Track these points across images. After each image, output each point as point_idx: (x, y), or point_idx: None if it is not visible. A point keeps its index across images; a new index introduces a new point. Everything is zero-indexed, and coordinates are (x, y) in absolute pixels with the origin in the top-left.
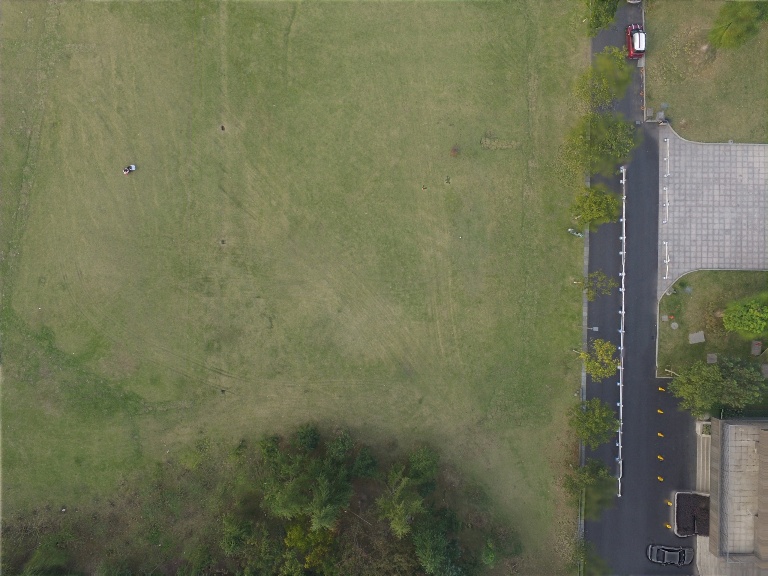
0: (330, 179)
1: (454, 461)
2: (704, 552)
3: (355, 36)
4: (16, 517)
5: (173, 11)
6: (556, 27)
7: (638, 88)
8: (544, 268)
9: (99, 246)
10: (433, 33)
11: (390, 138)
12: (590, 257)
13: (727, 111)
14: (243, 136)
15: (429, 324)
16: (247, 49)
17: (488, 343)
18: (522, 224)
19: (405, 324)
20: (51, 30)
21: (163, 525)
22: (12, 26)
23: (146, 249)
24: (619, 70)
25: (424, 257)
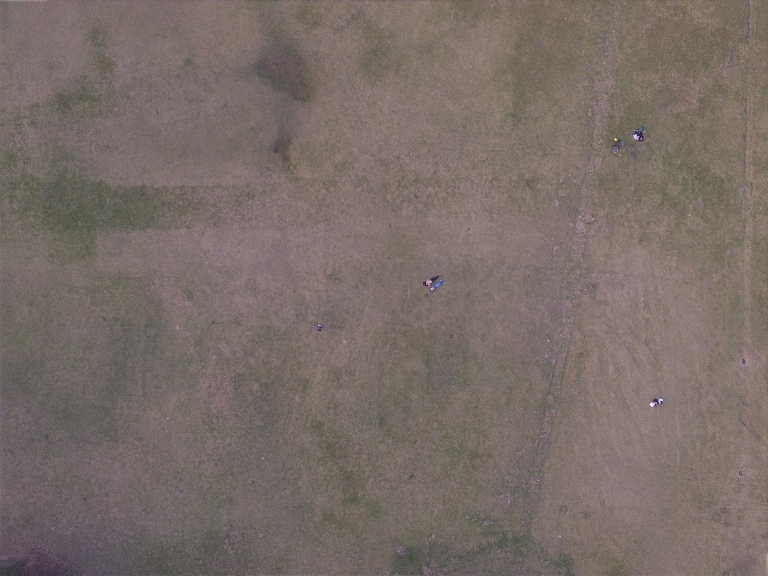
0: None
1: None
2: None
3: None
4: None
5: (700, 244)
6: None
7: None
8: None
9: (623, 477)
10: None
11: None
12: None
13: None
14: (764, 370)
15: None
16: None
17: None
18: None
19: None
20: (577, 258)
21: None
22: (538, 253)
23: (667, 480)
24: None
25: None
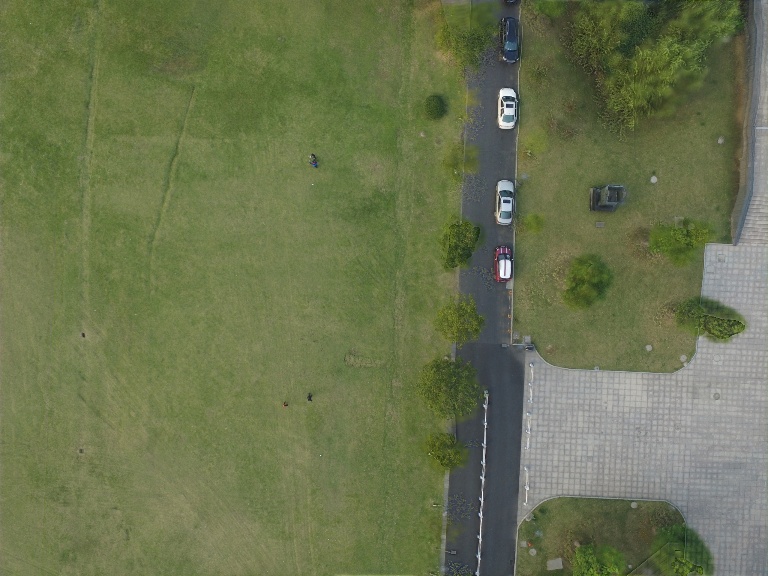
0: (190, 392)
1: None
2: None
3: (220, 247)
4: None
5: (35, 214)
6: (426, 244)
7: (506, 310)
8: (404, 489)
9: None
10: (300, 246)
11: (252, 353)
12: (450, 480)
13: (594, 338)
14: (104, 344)
15: (286, 543)
16: (110, 256)
17: (345, 563)
18: (384, 444)
19: (262, 542)
20: None
21: None
22: None
23: (2, 456)
24: (487, 291)
25: (283, 475)
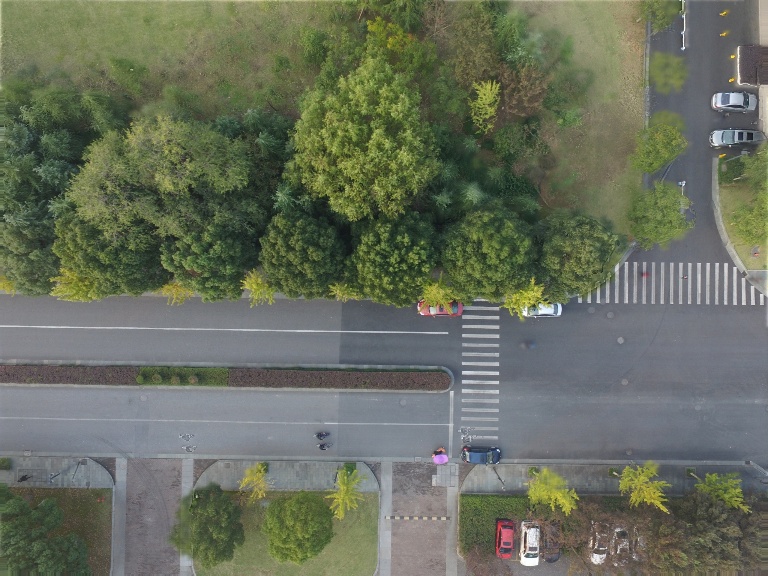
0: None
1: (521, 17)
2: (766, 104)
3: None
4: (83, 77)
5: None
6: None
7: None
8: None
9: None
10: None
11: None
12: None
13: None
14: None
15: None
16: None
17: None
18: None
19: None
20: None
21: (232, 79)
22: None
23: None
24: None
25: None
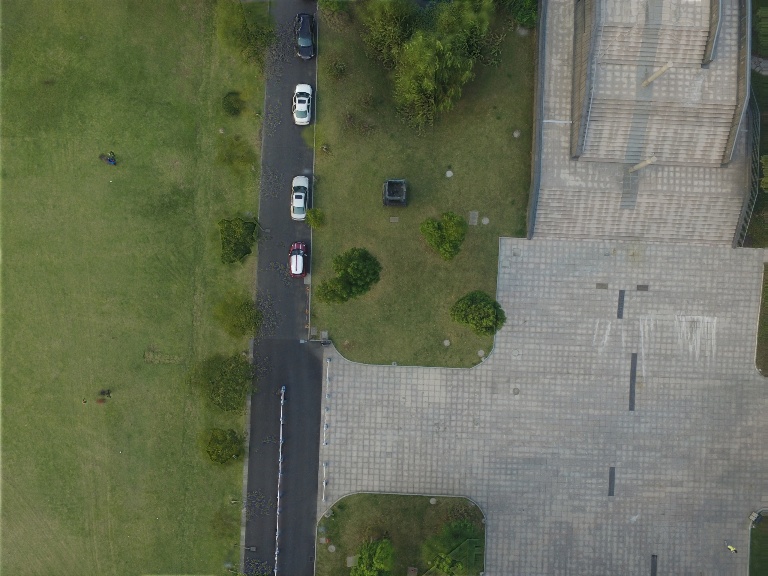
0: None
1: None
2: None
3: (19, 245)
4: None
5: None
6: None
7: (303, 306)
8: (204, 485)
9: None
10: (98, 243)
11: (51, 350)
12: (249, 476)
13: (390, 333)
14: None
15: (86, 539)
16: None
17: (145, 559)
18: (183, 440)
19: (62, 538)
20: None
21: None
22: None
23: None
24: (285, 287)
25: (83, 471)
